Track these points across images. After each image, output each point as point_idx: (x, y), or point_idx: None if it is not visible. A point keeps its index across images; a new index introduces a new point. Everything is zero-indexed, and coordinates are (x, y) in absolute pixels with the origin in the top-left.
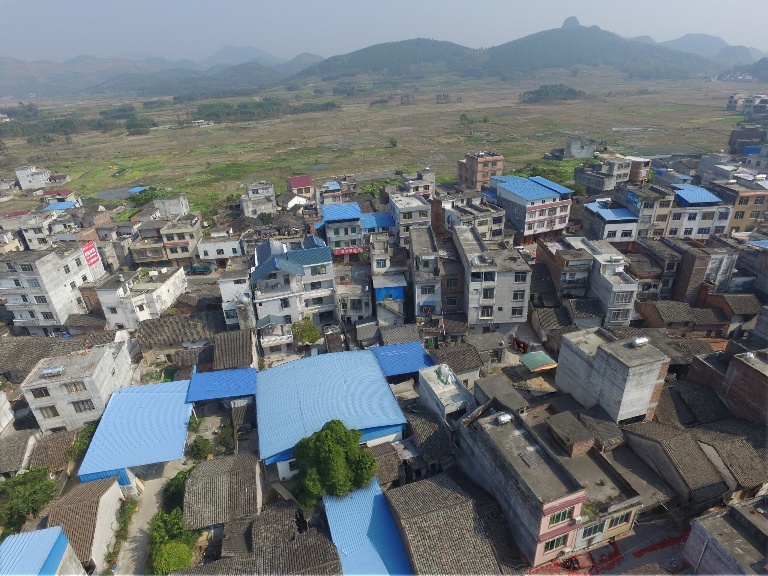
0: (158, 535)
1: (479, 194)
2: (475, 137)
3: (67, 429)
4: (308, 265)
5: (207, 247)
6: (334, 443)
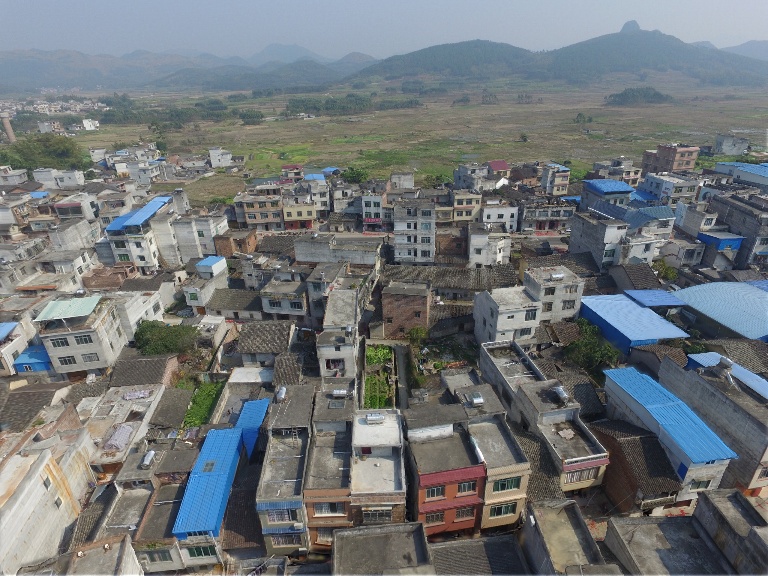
0: None
1: (725, 175)
2: (595, 135)
3: (550, 322)
4: (659, 219)
5: (491, 211)
6: None
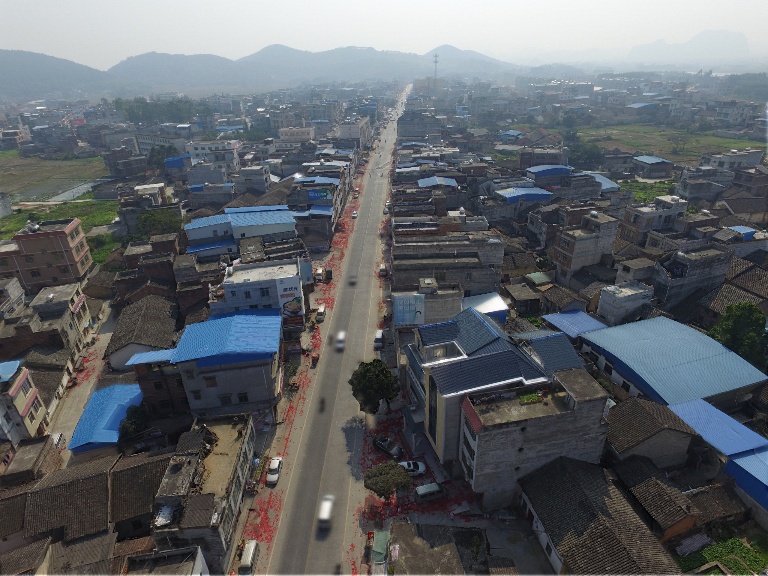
0: None
1: (253, 239)
2: None
3: None
4: None
5: None
6: None
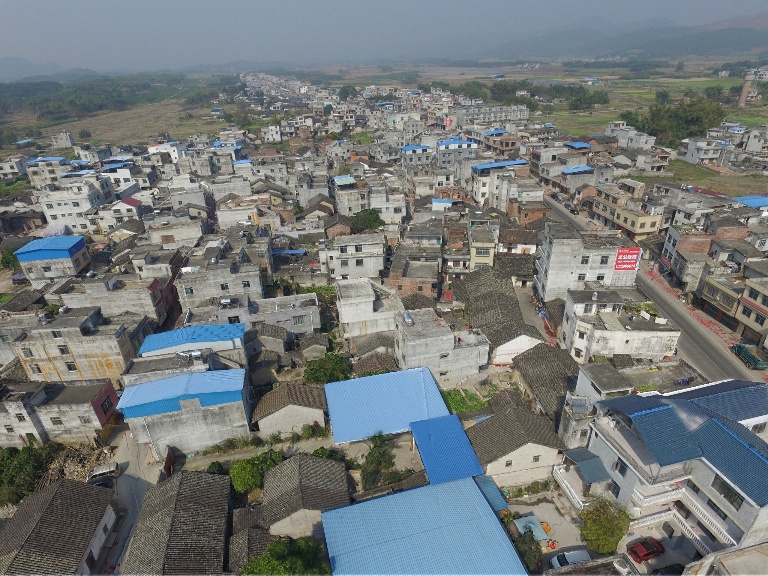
0: (260, 455)
1: None
2: None
3: (399, 362)
4: (713, 465)
5: None
6: (260, 573)
